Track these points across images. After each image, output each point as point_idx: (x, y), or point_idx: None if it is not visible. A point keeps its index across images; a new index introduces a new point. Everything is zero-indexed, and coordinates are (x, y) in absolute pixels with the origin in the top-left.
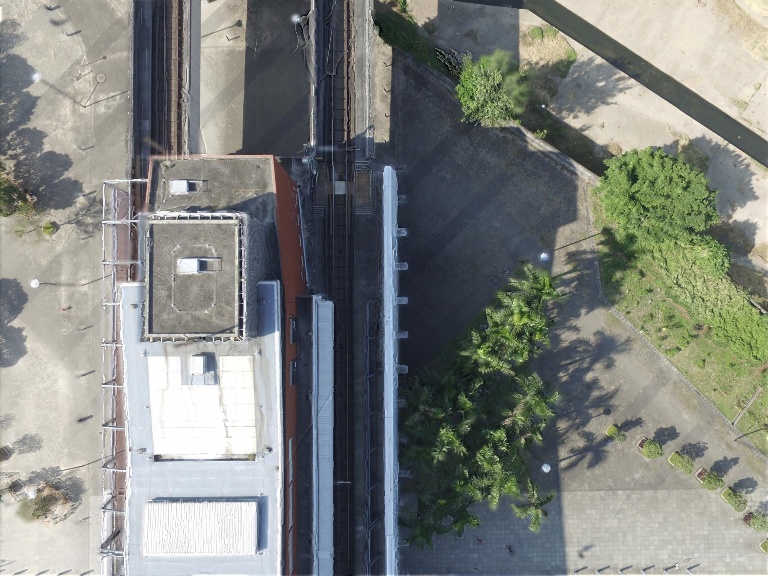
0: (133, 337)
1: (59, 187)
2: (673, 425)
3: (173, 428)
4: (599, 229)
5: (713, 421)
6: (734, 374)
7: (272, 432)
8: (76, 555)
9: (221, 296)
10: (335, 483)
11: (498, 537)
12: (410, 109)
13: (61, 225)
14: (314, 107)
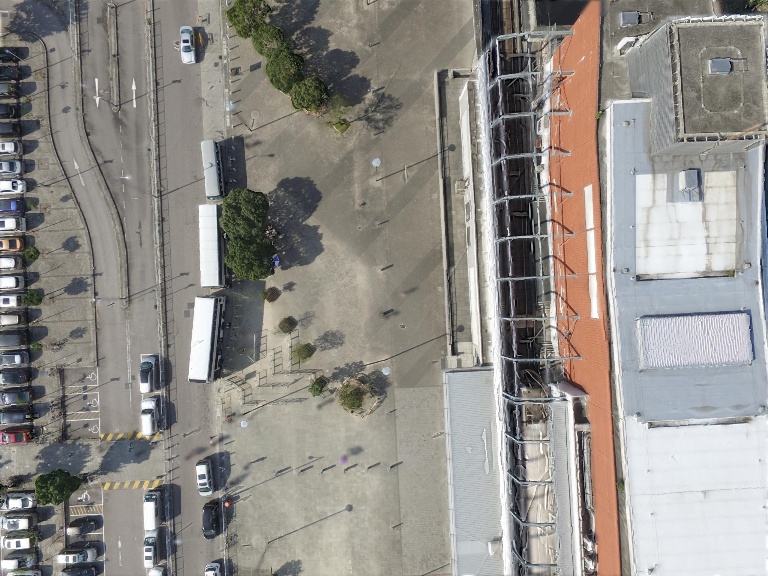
0: (623, 155)
1: (347, 84)
2: None
3: (656, 247)
4: None
5: None
6: None
7: (751, 247)
8: (384, 448)
9: (748, 96)
10: None
11: None
12: None
13: (351, 122)
14: None
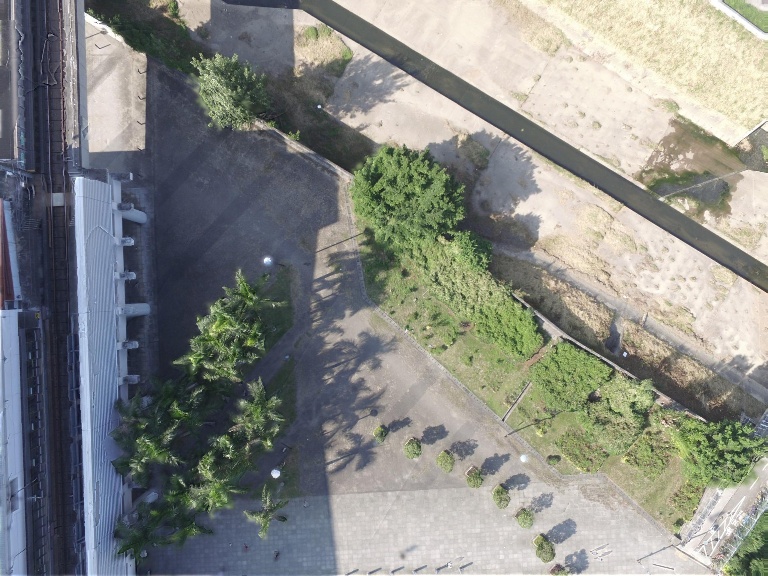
0: None
1: None
2: (442, 424)
3: None
4: (361, 229)
5: (483, 418)
6: (502, 370)
7: None
8: None
9: None
10: (62, 497)
11: (266, 543)
12: (166, 116)
13: None
14: (19, 119)
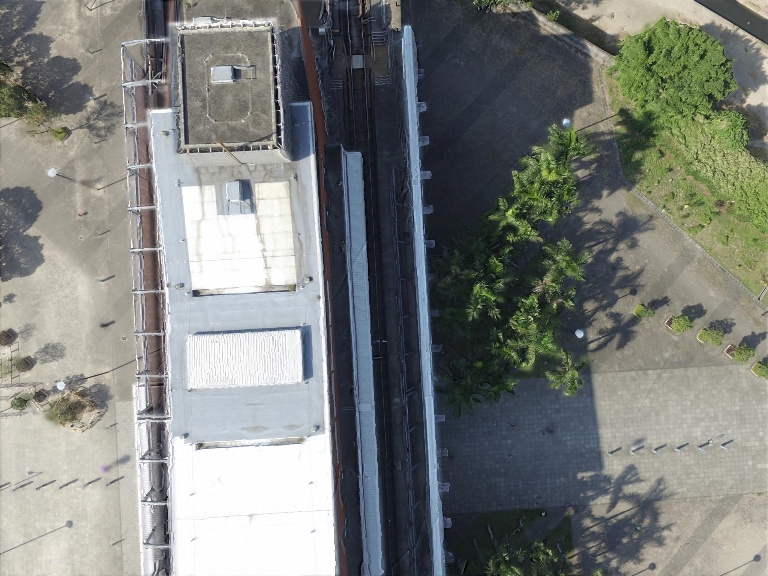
0: (166, 167)
1: (69, 92)
2: (700, 302)
3: (210, 261)
4: (616, 110)
5: (739, 297)
6: (758, 249)
7: (312, 260)
8: (104, 463)
9: (257, 105)
10: None
11: (531, 422)
12: None
13: (73, 130)
14: None
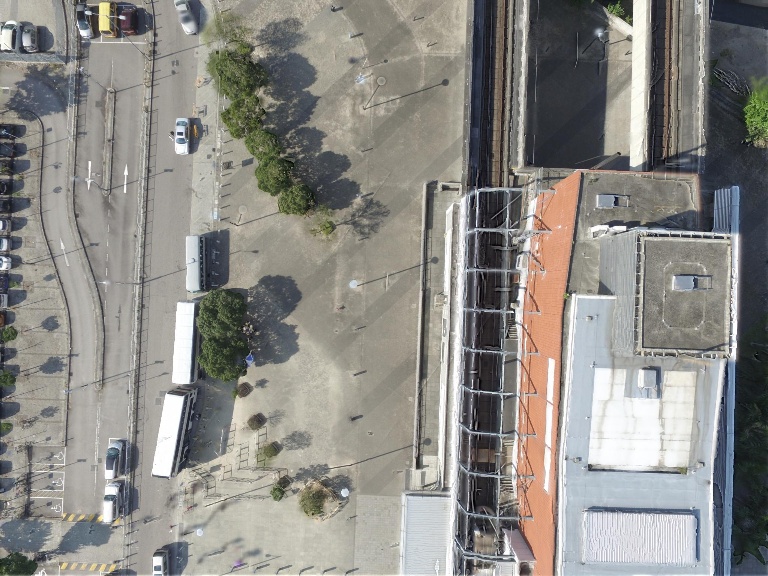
0: (583, 348)
1: (337, 187)
2: None
3: (610, 439)
4: None
5: None
6: None
7: (706, 447)
8: (341, 553)
9: (710, 314)
10: None
11: None
12: None
13: (337, 225)
14: (647, 123)
